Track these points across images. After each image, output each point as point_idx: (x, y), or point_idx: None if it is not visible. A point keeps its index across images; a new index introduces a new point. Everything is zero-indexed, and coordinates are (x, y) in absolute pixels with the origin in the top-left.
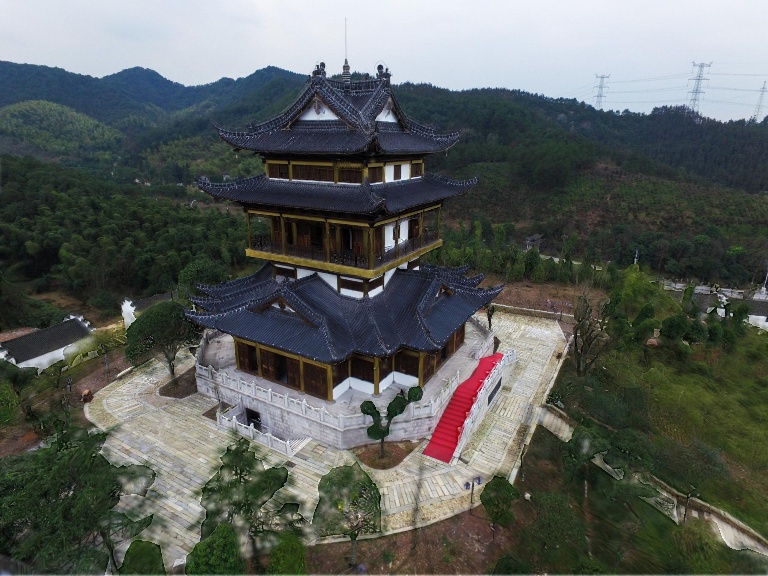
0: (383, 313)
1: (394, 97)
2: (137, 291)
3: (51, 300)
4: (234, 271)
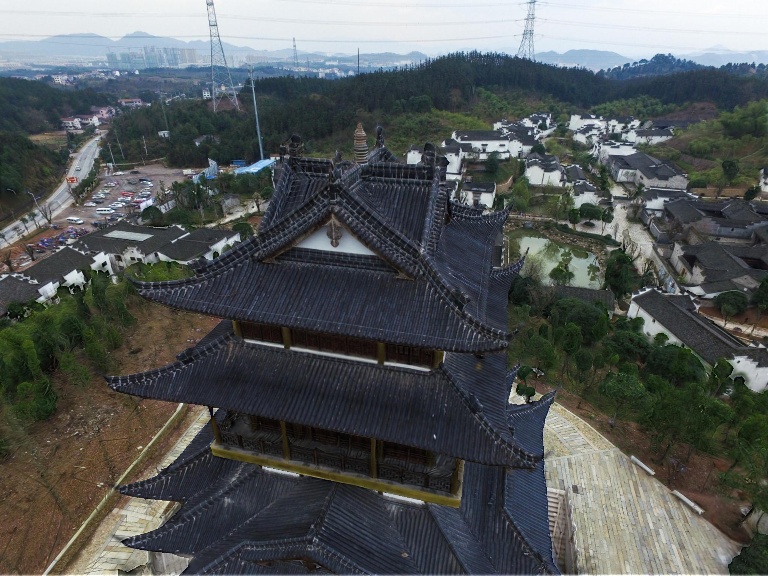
0: None
1: None
2: None
3: None
4: None
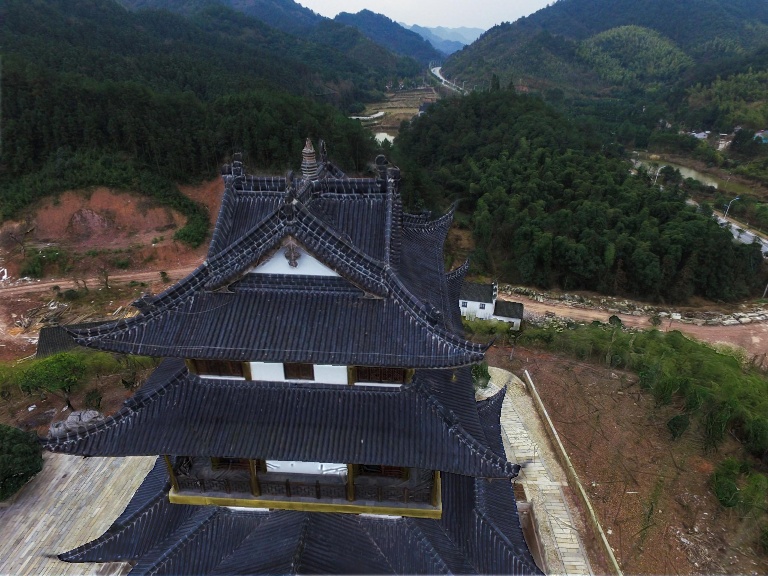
0: (224, 544)
1: (327, 232)
2: (512, 258)
3: (460, 238)
4: (612, 275)
